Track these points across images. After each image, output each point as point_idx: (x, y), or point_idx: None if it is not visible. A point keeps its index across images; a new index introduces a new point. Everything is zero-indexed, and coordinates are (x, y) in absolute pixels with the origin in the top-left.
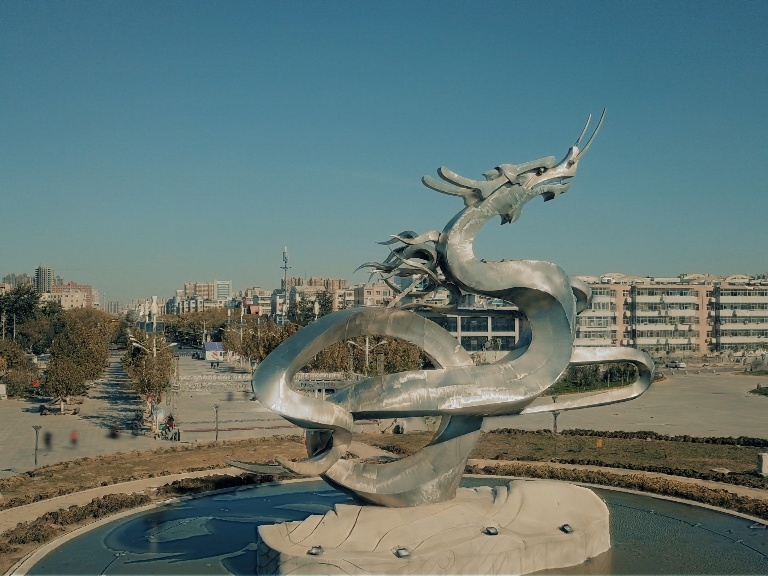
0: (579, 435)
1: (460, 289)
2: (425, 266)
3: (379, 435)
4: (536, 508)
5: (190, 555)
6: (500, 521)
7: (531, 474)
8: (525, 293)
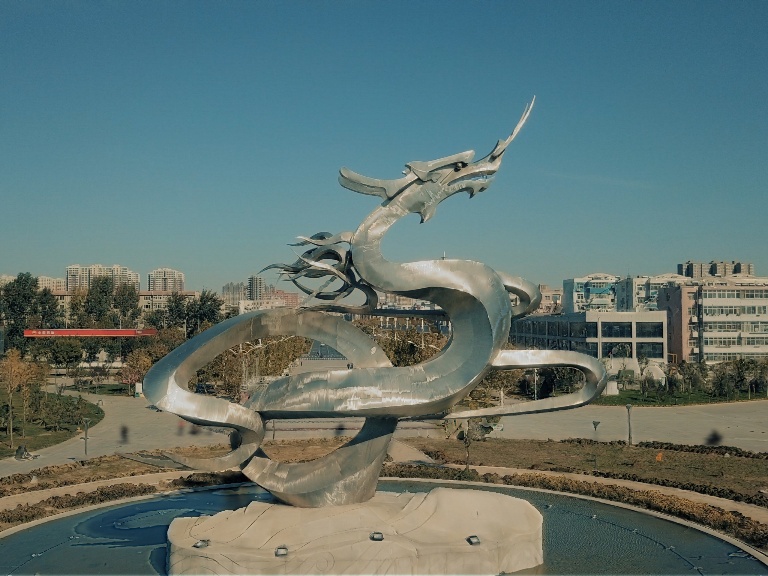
0: (653, 448)
1: (375, 290)
2: (333, 267)
3: (442, 440)
4: (449, 517)
5: (135, 542)
6: (400, 527)
7: (544, 485)
8: (444, 293)
